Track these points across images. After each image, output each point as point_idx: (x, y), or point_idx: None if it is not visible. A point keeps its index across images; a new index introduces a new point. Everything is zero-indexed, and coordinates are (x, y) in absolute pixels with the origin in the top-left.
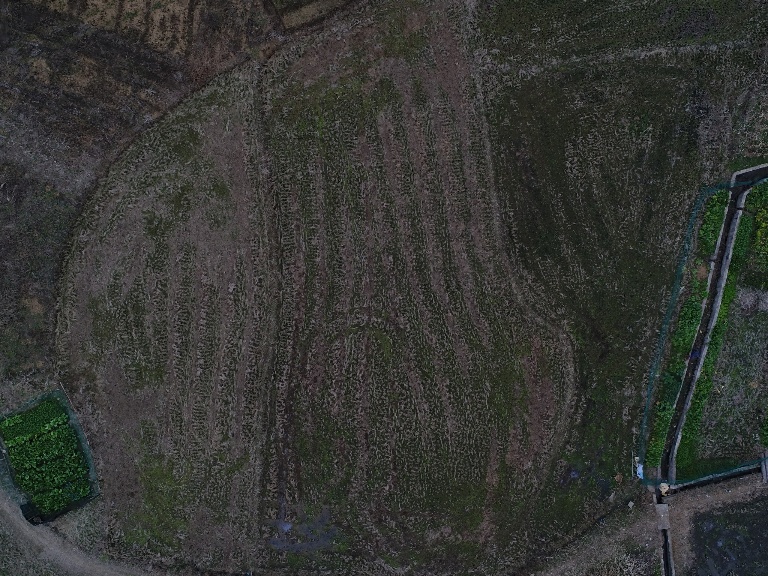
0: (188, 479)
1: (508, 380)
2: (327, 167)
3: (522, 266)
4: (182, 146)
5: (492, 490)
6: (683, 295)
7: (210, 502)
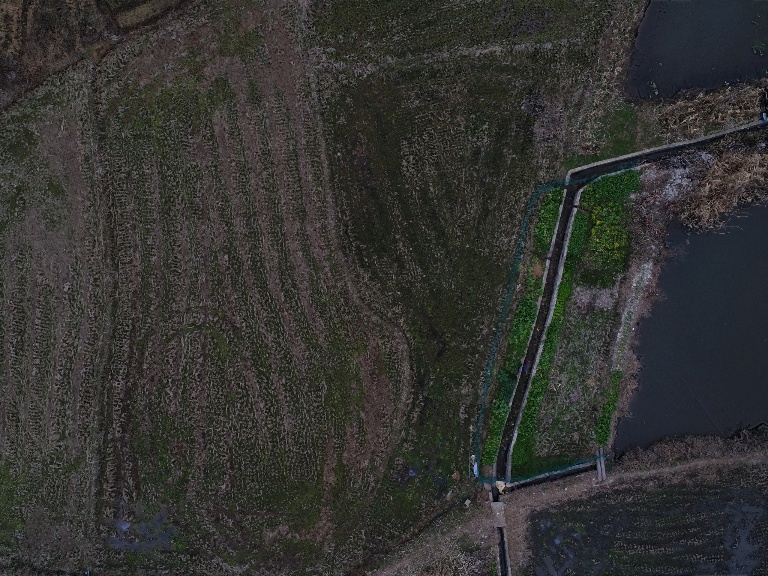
0: (25, 479)
1: (345, 379)
2: (163, 166)
3: (358, 265)
4: (17, 146)
5: (329, 489)
6: (519, 293)
7: (47, 501)
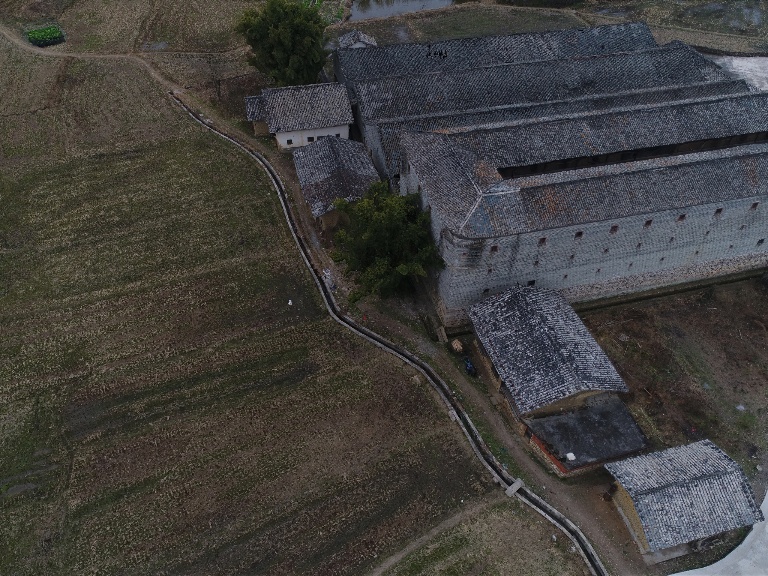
0: None
1: None
2: None
3: (244, 2)
4: None
5: None
6: None
7: None
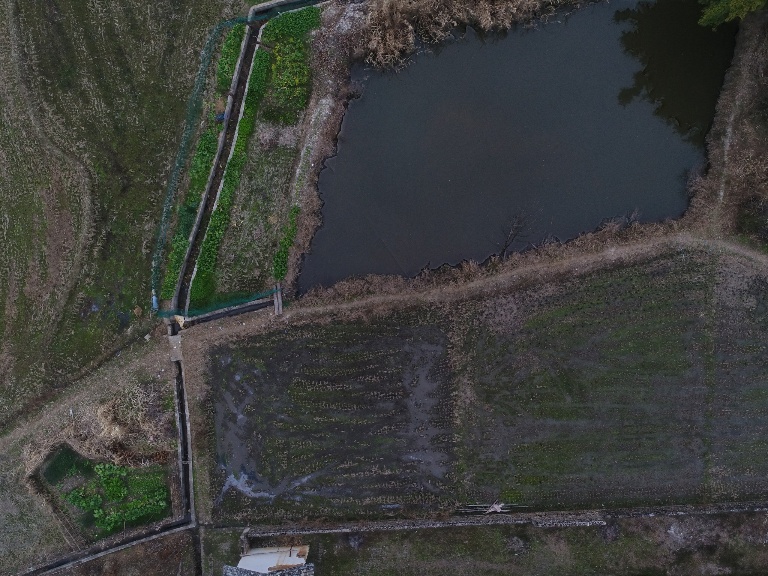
0: None
1: (27, 212)
2: None
3: (43, 99)
4: None
5: (11, 322)
6: (203, 129)
7: None
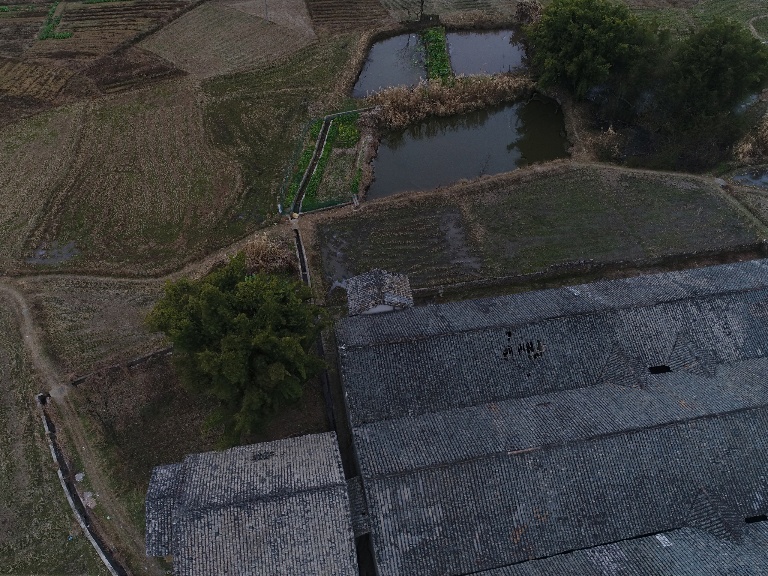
0: None
1: None
2: None
3: (215, 148)
4: None
5: (187, 225)
6: None
7: None
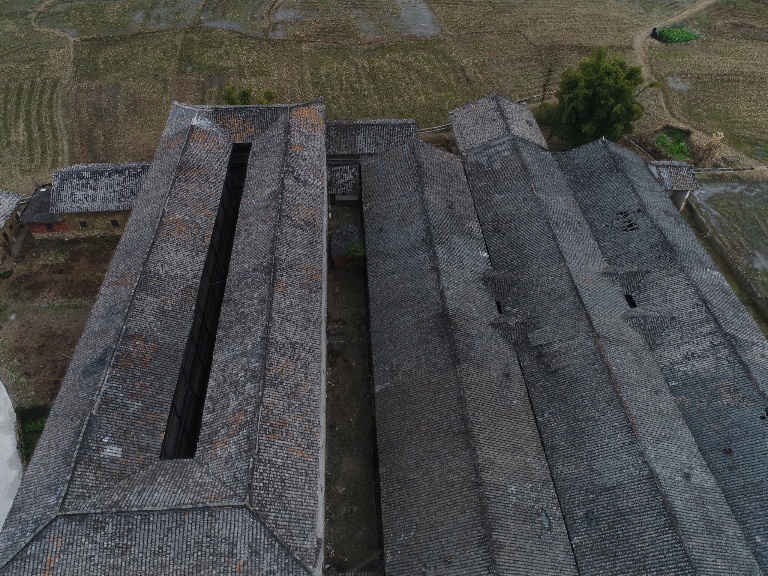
0: None
1: None
2: None
3: None
4: None
5: None
6: None
7: None
